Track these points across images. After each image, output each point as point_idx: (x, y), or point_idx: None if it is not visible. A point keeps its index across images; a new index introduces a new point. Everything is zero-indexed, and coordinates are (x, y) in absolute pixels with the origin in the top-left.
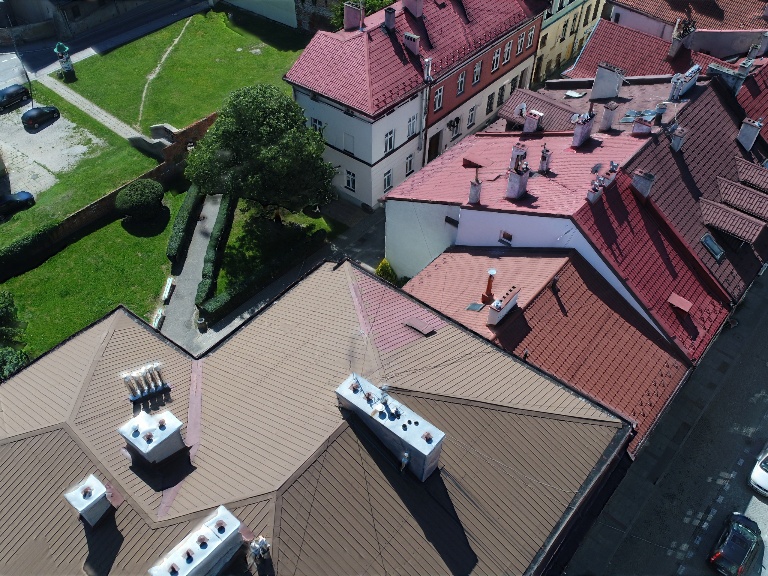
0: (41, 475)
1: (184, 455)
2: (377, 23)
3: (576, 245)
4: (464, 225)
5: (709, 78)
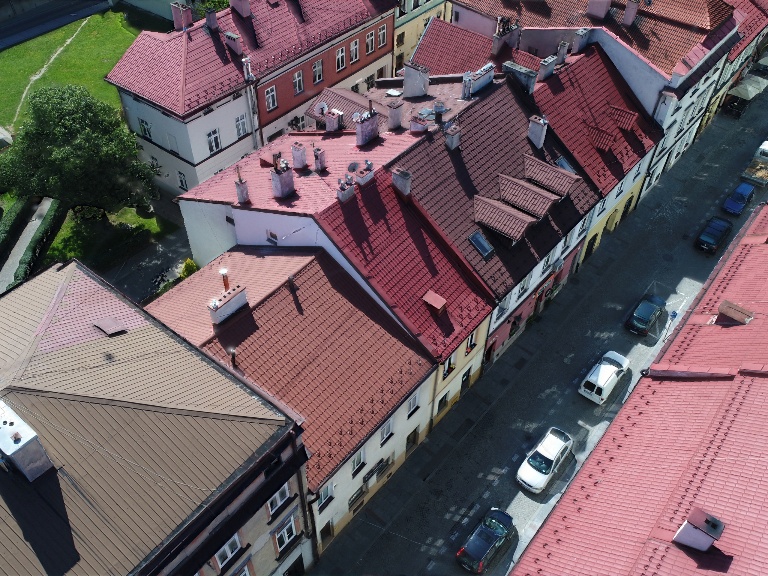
0: None
1: None
2: (201, 23)
3: (323, 244)
4: (239, 224)
5: (505, 76)
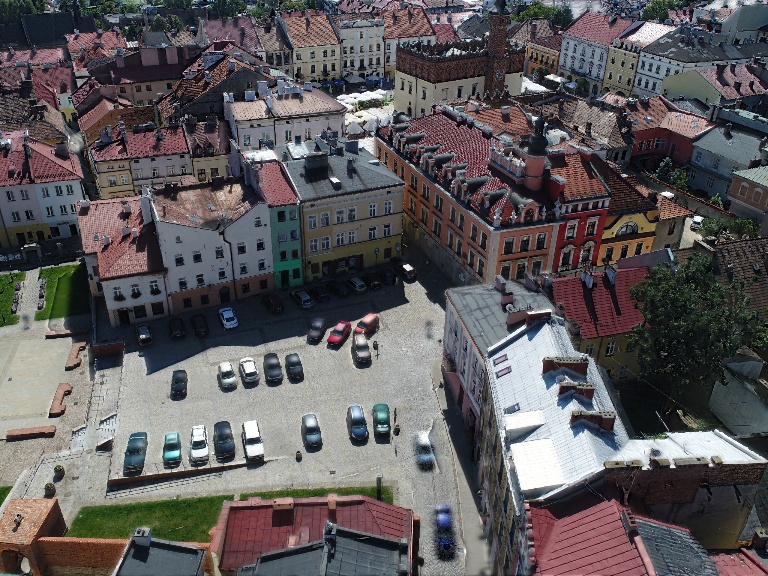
0: None
1: None
2: None
3: None
4: None
5: None
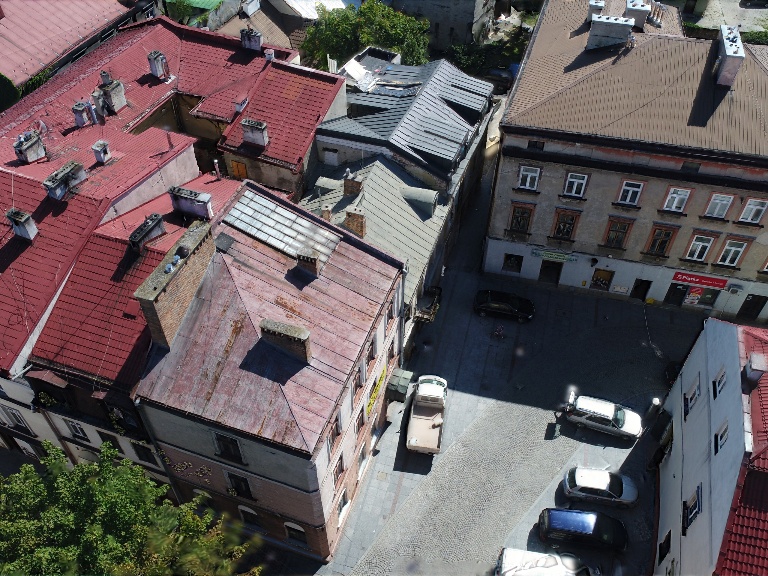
0: (588, 6)
1: (639, 30)
2: None
3: None
4: None
5: None
